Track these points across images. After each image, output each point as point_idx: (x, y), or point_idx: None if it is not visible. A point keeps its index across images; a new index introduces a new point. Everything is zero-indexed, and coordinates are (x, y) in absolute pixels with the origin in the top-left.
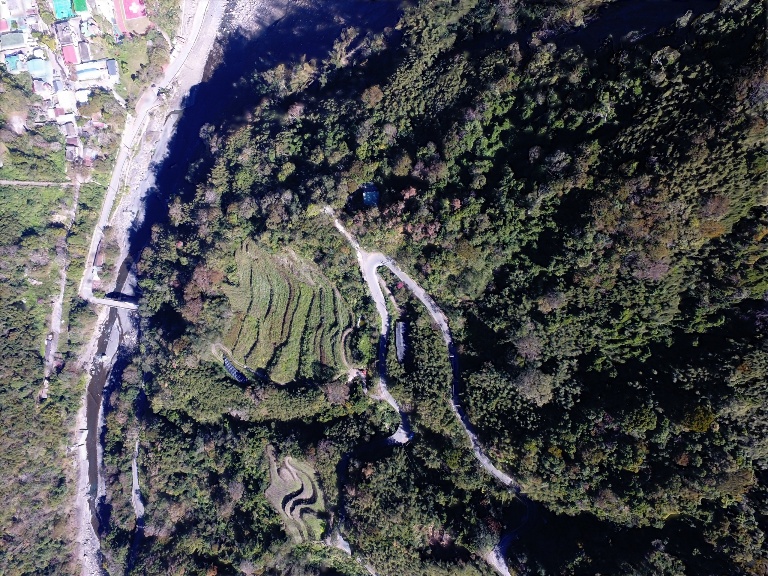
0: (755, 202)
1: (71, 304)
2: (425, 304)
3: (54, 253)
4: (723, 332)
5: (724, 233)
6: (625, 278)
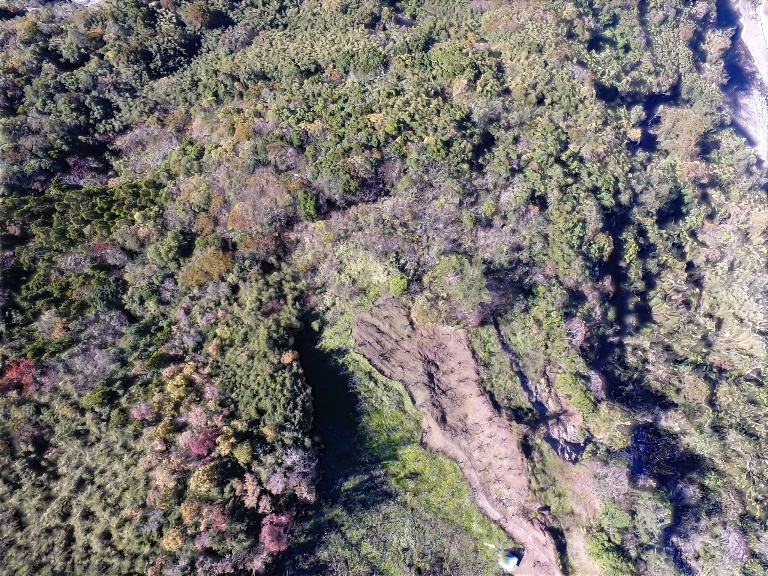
0: None
1: None
2: None
3: None
4: None
5: None
6: None
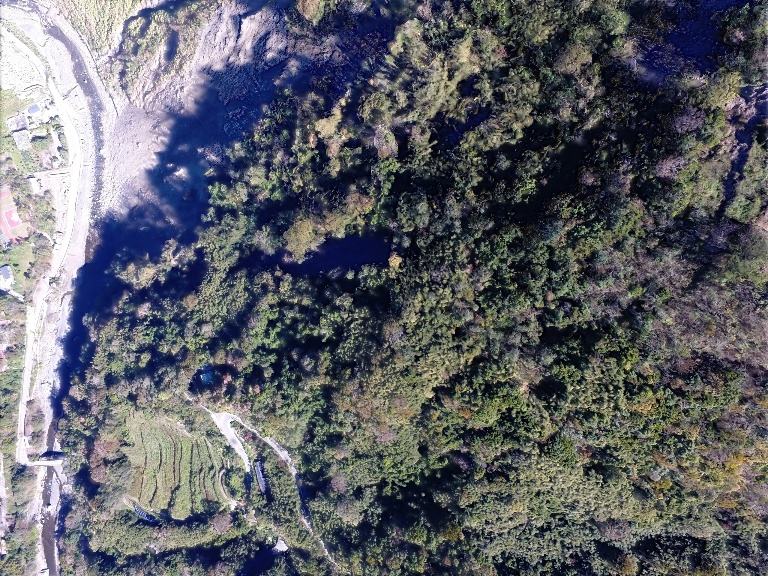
0: (423, 396)
1: (11, 473)
2: (272, 446)
3: None
4: (451, 468)
5: (417, 413)
6: None
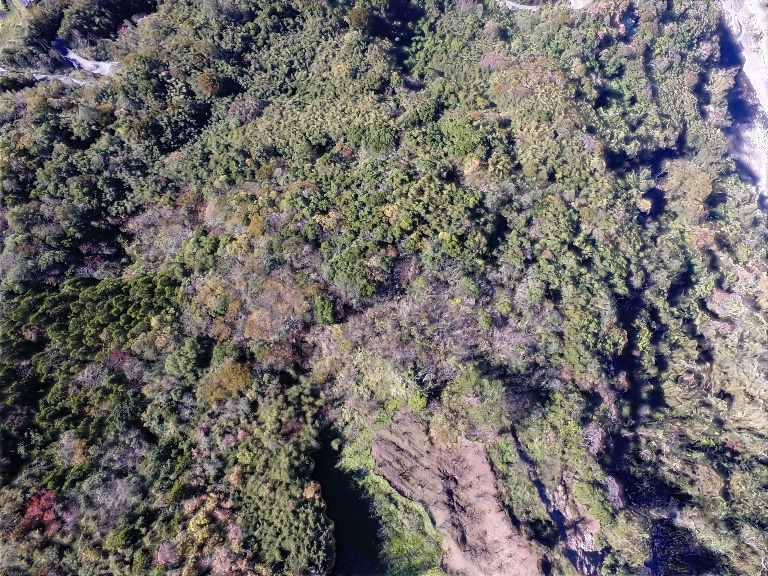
0: None
1: None
2: (524, 6)
3: None
4: None
5: None
6: None
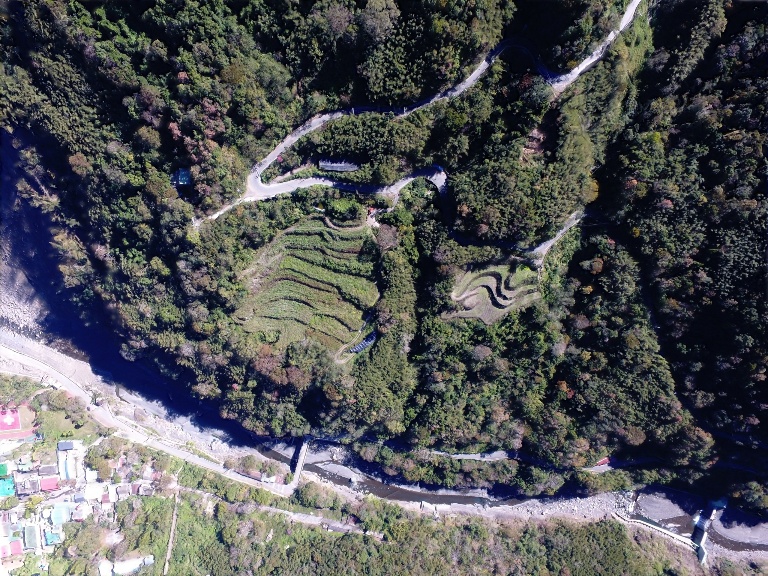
0: None
1: (295, 504)
2: None
3: (243, 515)
4: None
5: None
6: None
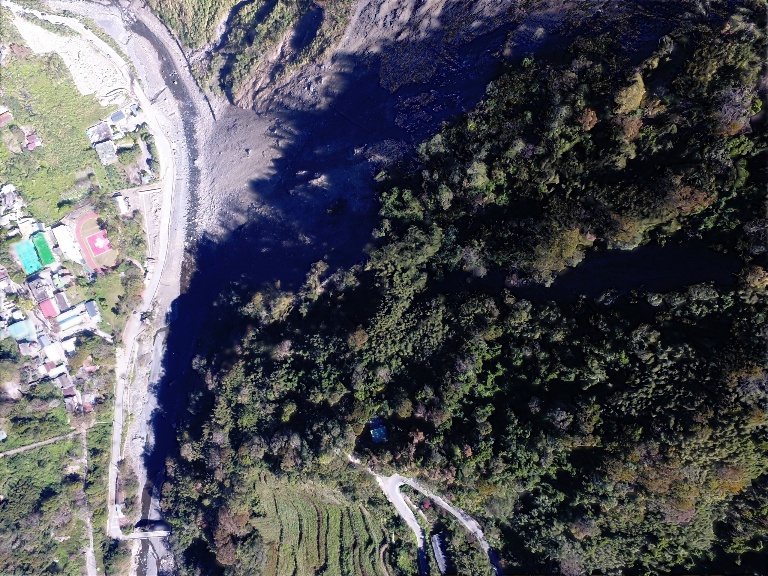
0: None
1: (103, 550)
2: (455, 515)
3: (75, 506)
4: (763, 553)
5: (744, 485)
6: (653, 512)
